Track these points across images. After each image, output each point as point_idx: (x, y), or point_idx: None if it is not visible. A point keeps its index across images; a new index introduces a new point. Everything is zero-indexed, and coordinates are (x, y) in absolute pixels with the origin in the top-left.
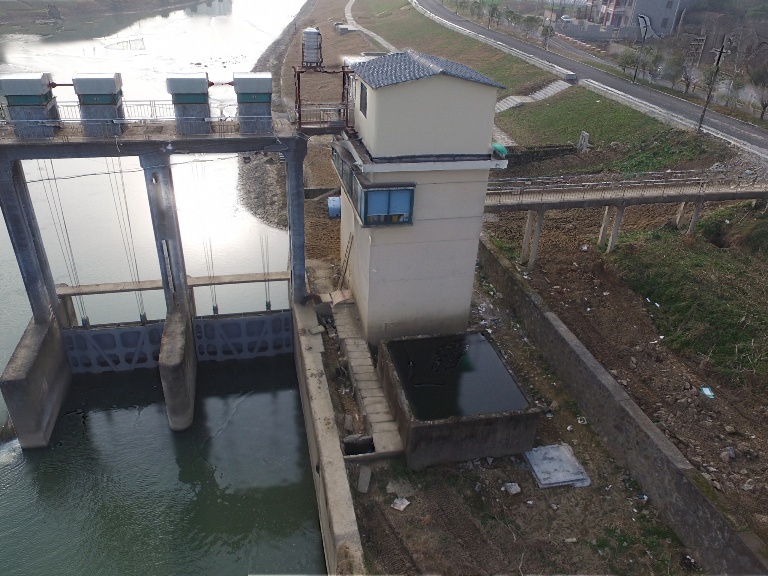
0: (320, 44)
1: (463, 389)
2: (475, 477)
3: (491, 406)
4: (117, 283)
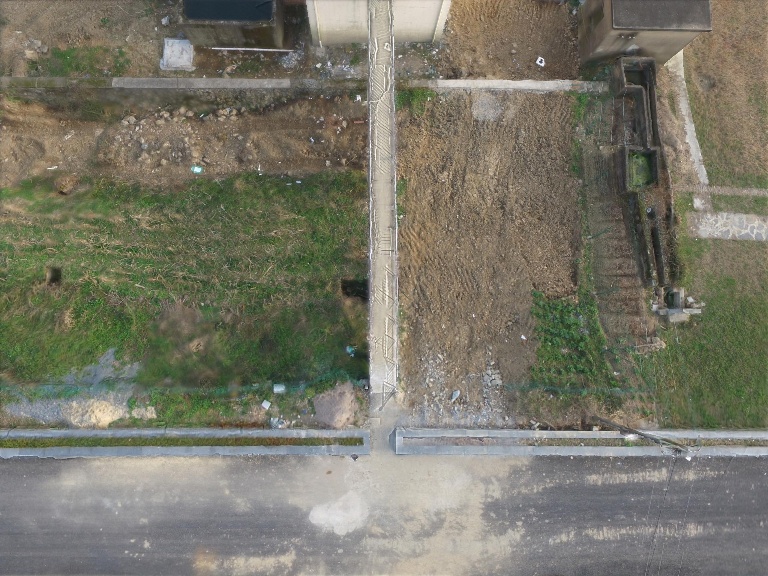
0: None
1: (236, 6)
2: (176, 2)
3: (199, 3)
4: None
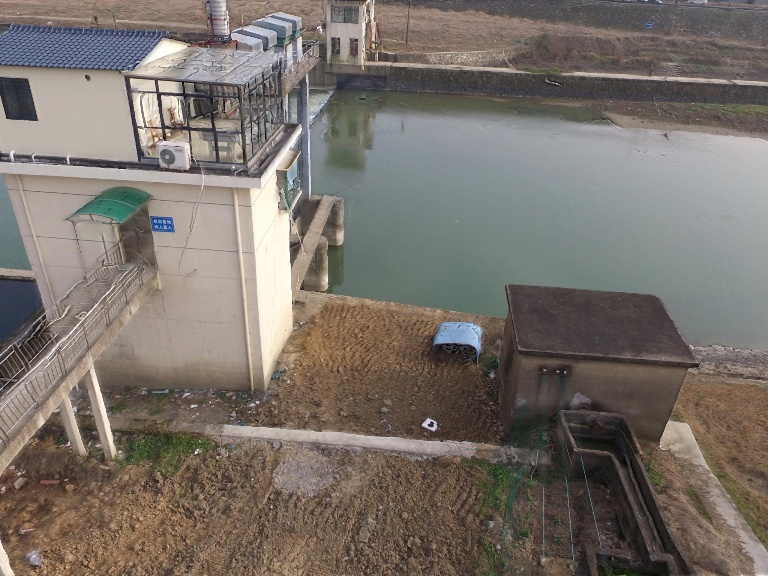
0: (209, 14)
1: None
2: None
3: None
4: (326, 215)
